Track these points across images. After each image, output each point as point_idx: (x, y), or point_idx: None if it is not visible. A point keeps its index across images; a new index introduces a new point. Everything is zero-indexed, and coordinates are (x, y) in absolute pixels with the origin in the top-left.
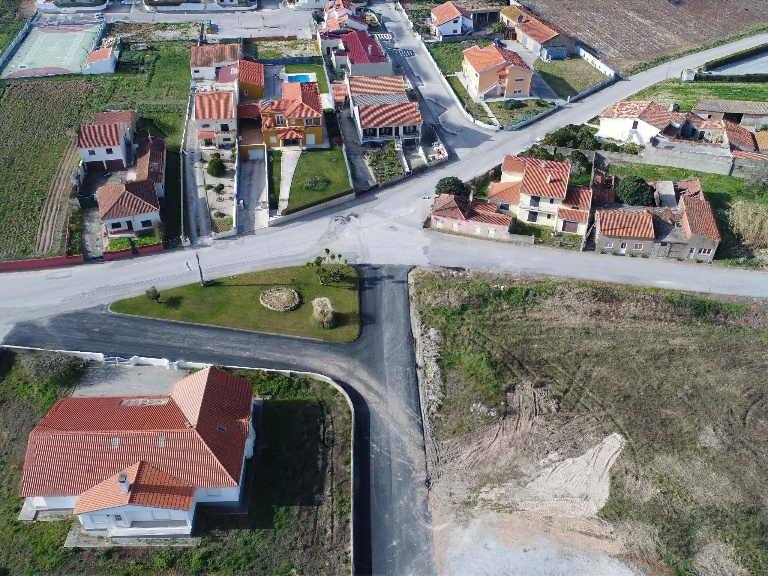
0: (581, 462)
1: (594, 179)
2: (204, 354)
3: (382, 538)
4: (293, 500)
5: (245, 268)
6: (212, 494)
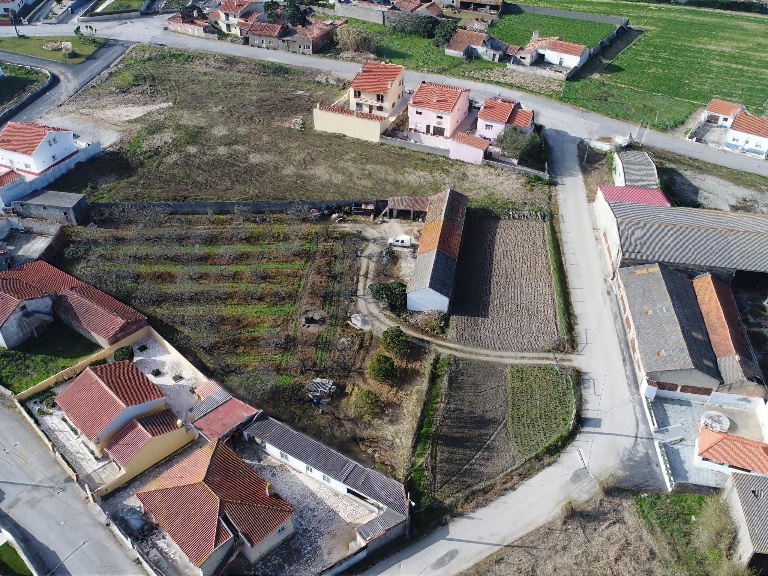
0: None
1: (277, 12)
2: None
3: None
4: None
5: (48, 34)
6: None
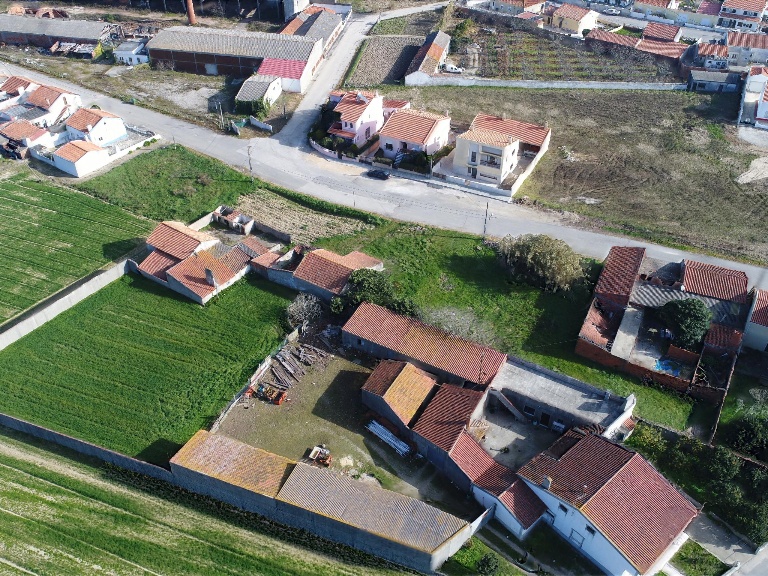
0: (767, 174)
1: None
2: None
3: None
4: None
5: None
6: None
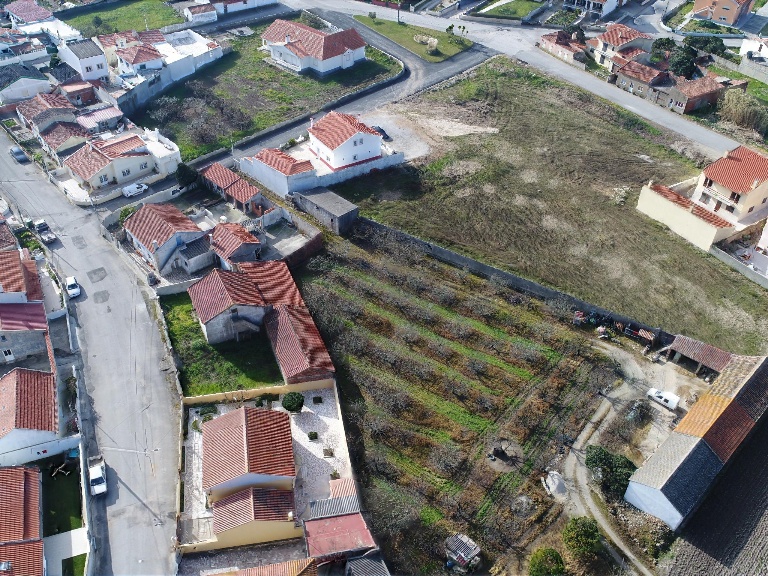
0: (465, 126)
1: (665, 53)
2: (369, 41)
3: (356, 103)
4: (342, 83)
5: (425, 26)
6: (315, 64)
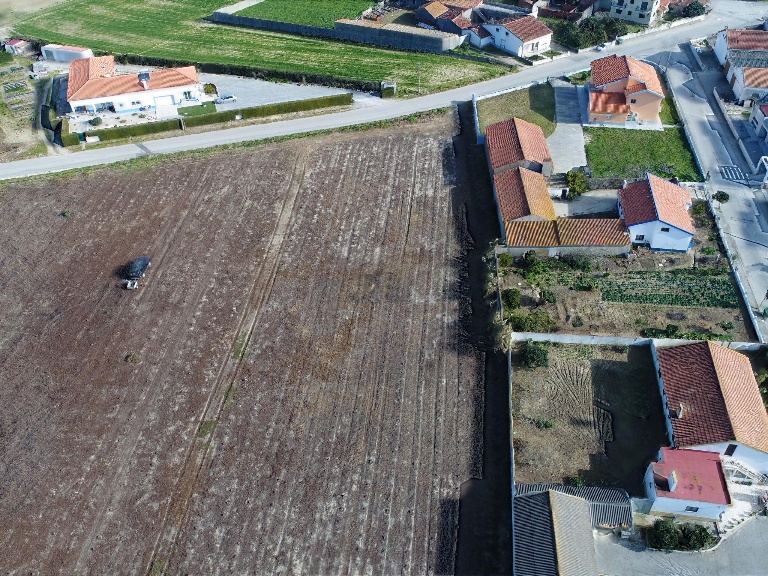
0: None
1: None
2: None
3: None
4: None
5: None
6: None
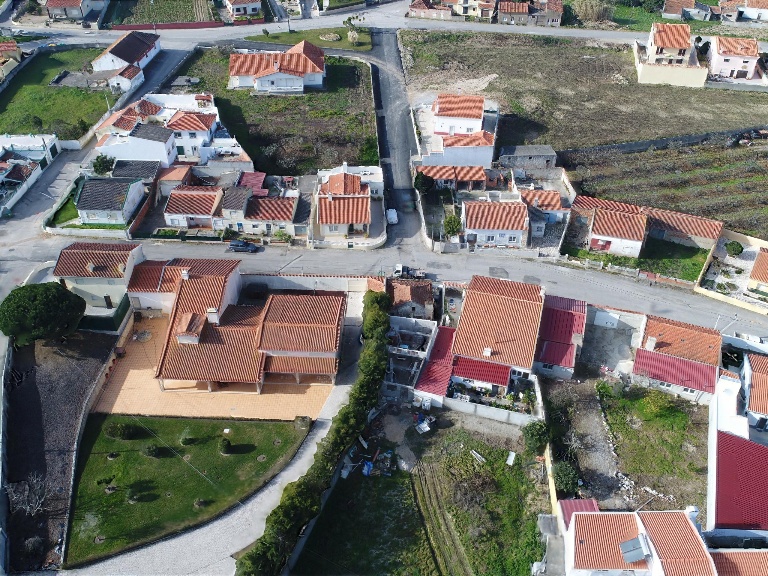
0: (477, 80)
1: None
2: None
3: (386, 95)
4: (346, 87)
5: (310, 28)
6: (311, 80)
